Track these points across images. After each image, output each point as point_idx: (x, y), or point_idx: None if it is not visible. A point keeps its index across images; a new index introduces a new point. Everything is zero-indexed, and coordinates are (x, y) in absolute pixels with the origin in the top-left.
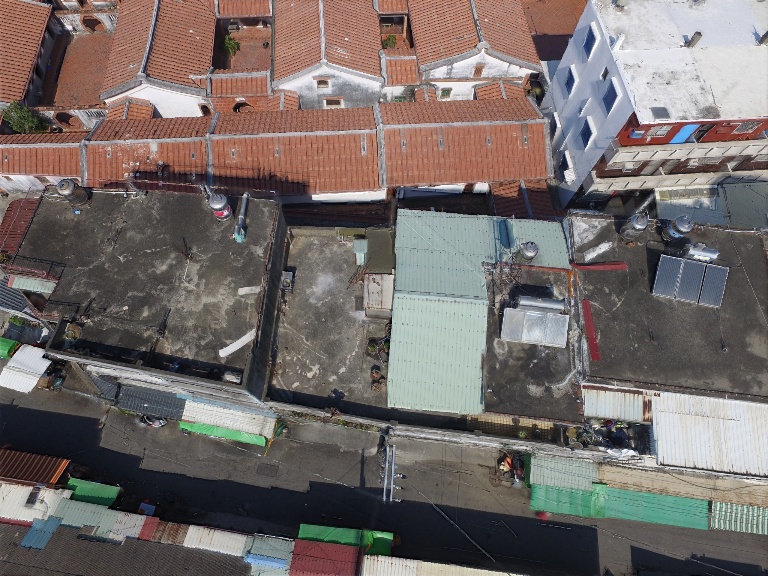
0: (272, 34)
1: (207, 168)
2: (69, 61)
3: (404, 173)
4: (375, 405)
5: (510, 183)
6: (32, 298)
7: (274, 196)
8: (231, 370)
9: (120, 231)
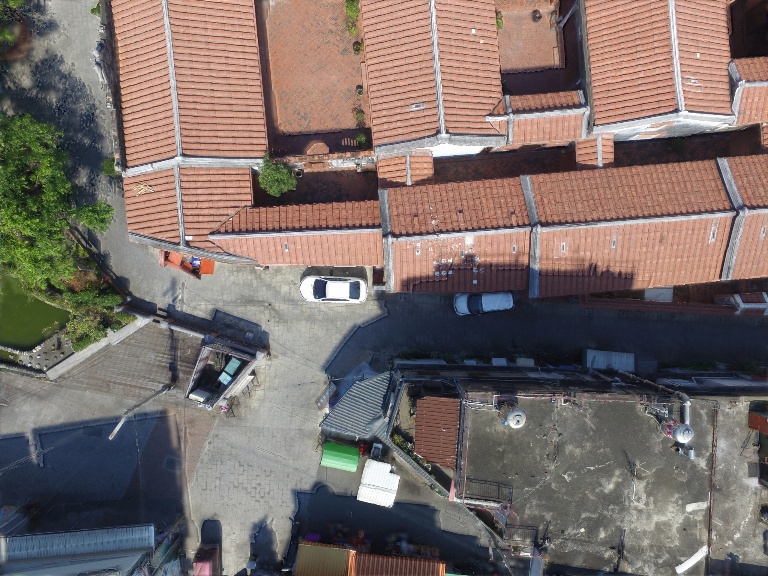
0: (584, 34)
1: (531, 264)
2: (276, 50)
3: (754, 265)
4: (766, 566)
5: None
6: (443, 483)
7: None
8: None
9: (558, 446)
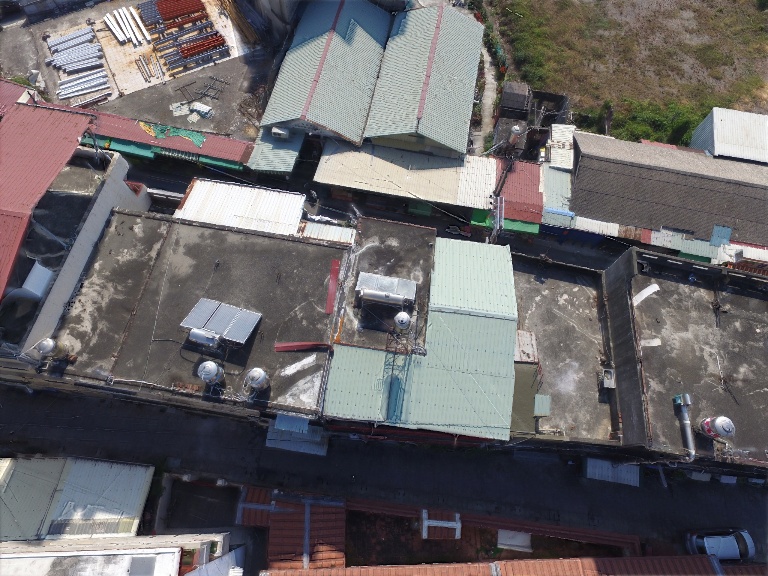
0: None
1: None
2: None
3: None
4: None
5: (321, 568)
6: None
7: (633, 557)
8: (644, 272)
9: None
